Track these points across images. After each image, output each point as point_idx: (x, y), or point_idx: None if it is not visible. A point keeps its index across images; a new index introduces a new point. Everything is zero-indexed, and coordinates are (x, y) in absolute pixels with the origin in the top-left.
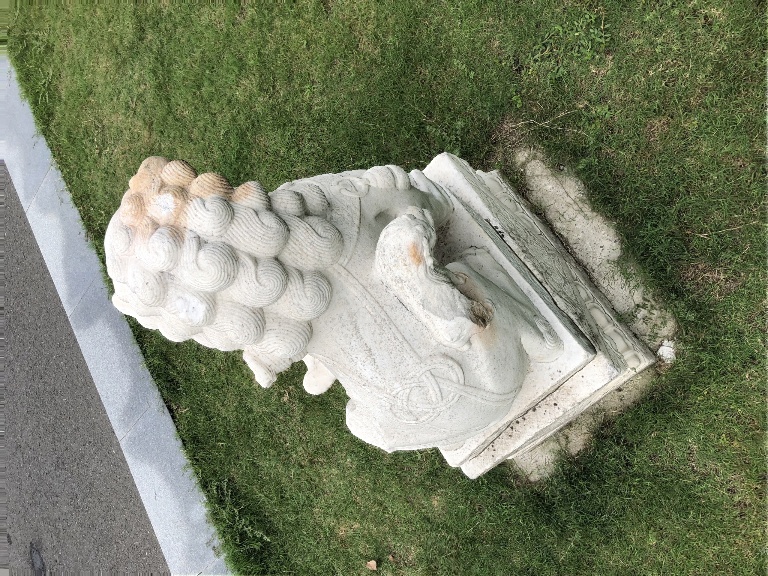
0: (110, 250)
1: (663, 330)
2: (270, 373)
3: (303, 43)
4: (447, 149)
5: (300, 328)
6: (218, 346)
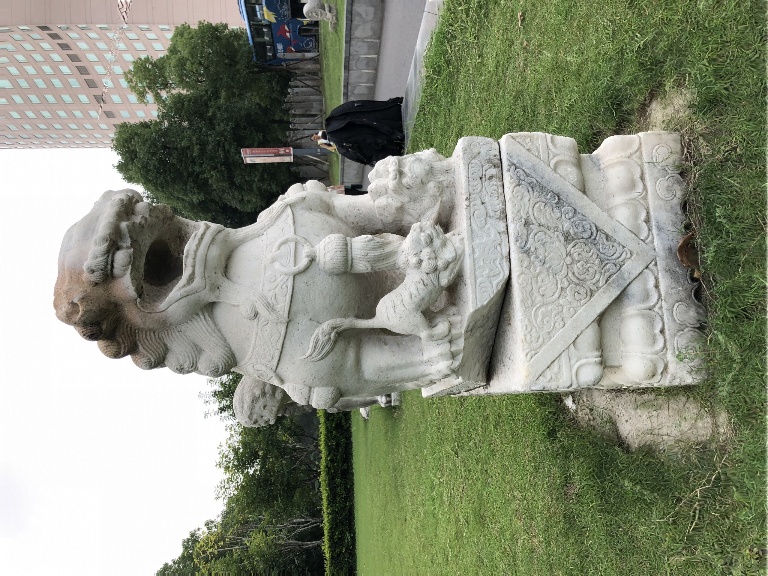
0: None
1: (580, 412)
2: None
3: None
4: (731, 333)
5: None
6: None
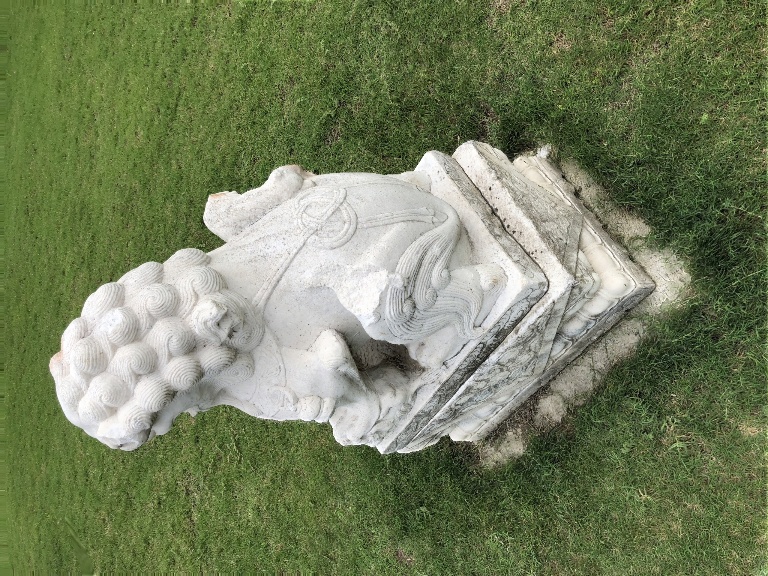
0: None
1: None
2: None
3: (310, 505)
4: None
5: None
6: (167, 337)
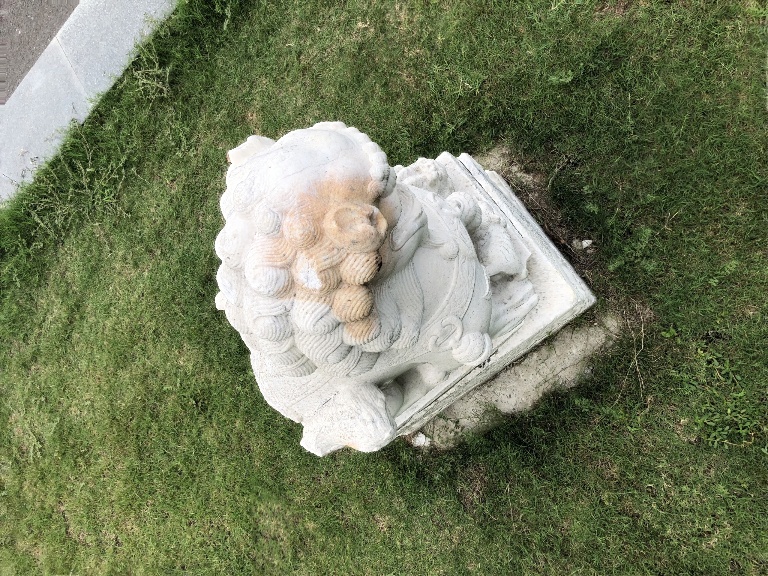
0: (258, 194)
1: None
2: None
3: None
4: (627, 245)
5: None
6: None
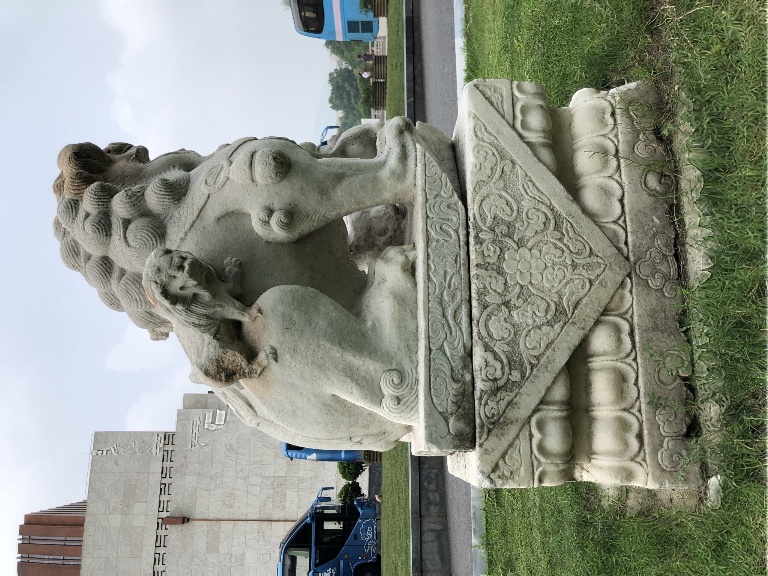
0: None
1: None
2: (154, 332)
3: None
4: None
5: (138, 314)
6: None
